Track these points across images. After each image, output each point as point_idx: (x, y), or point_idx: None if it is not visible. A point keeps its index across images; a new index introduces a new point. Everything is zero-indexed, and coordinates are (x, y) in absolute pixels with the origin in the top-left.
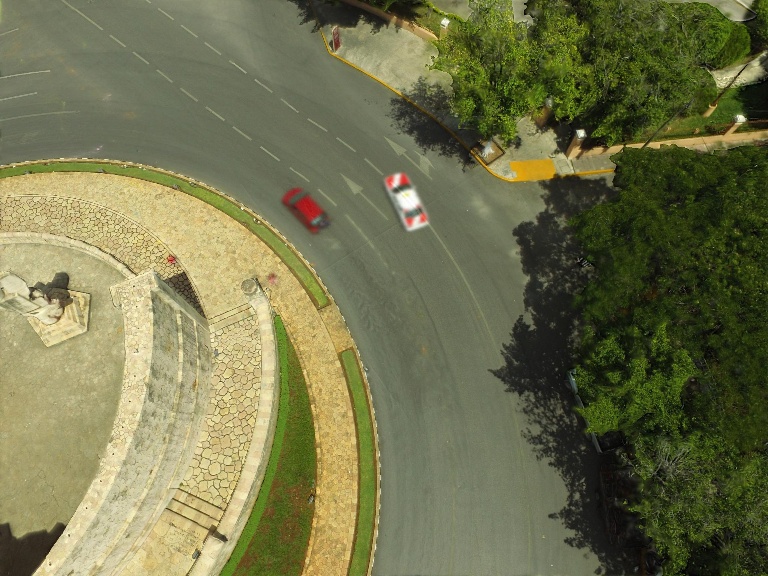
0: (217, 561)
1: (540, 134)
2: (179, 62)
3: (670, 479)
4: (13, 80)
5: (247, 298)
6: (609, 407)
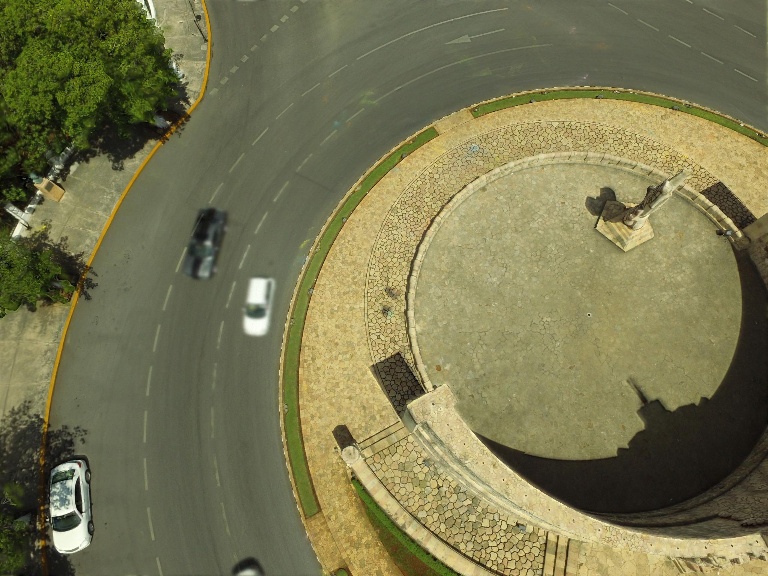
0: None
1: None
2: None
3: None
4: (476, 18)
5: None
6: None
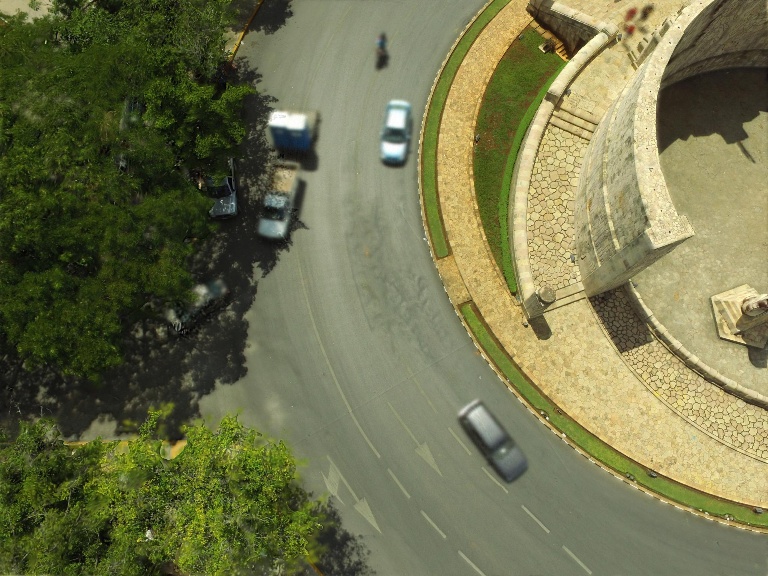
0: None
1: None
2: None
3: None
4: None
5: None
6: None
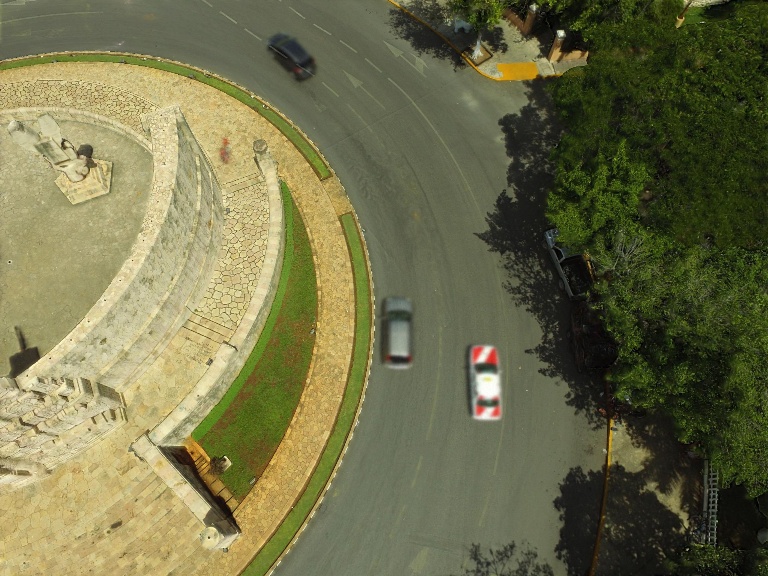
0: (228, 367)
1: (525, 41)
2: None
3: (626, 272)
4: None
5: (258, 157)
6: (576, 217)
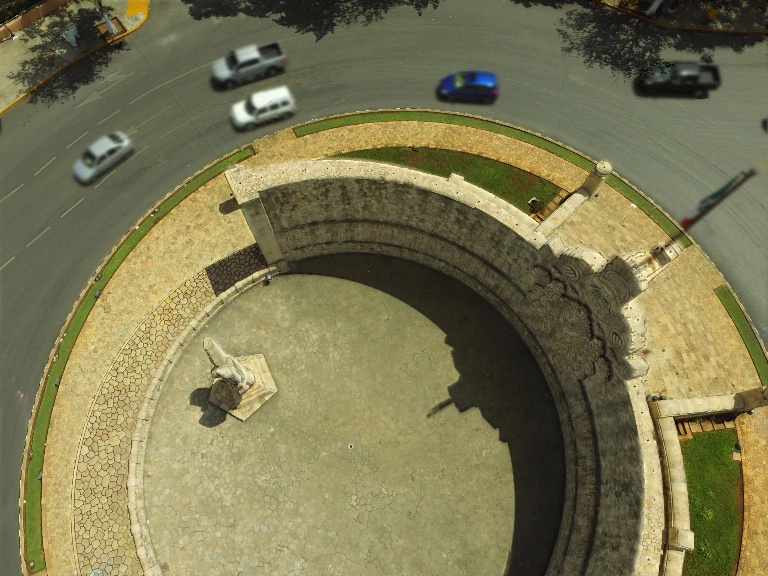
0: None
1: None
2: None
3: None
4: None
5: None
6: None
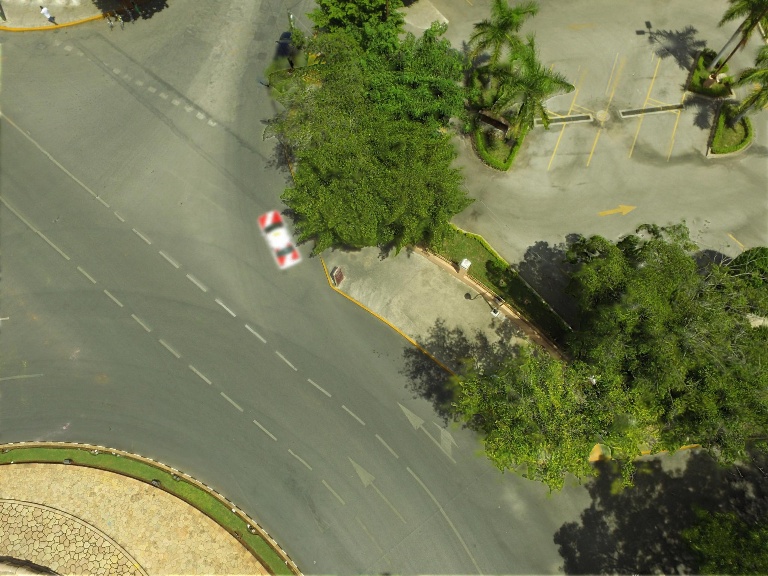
0: None
1: None
2: (157, 303)
3: None
4: None
5: None
6: None
